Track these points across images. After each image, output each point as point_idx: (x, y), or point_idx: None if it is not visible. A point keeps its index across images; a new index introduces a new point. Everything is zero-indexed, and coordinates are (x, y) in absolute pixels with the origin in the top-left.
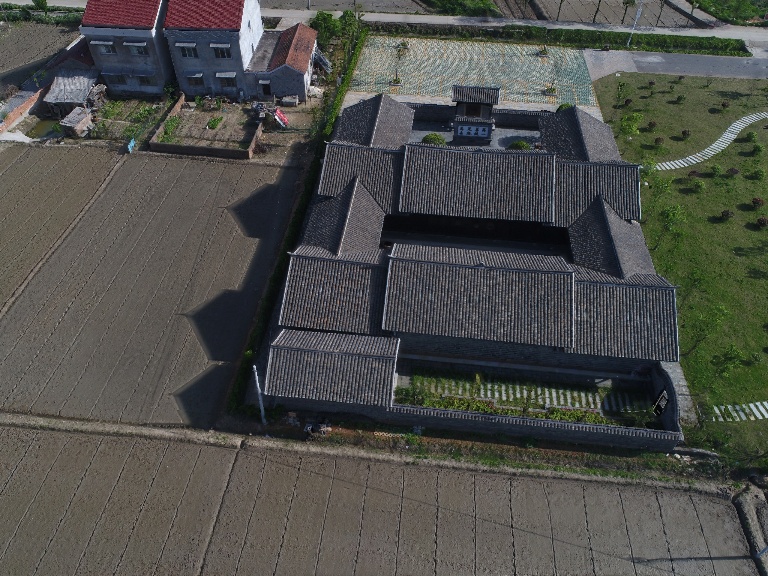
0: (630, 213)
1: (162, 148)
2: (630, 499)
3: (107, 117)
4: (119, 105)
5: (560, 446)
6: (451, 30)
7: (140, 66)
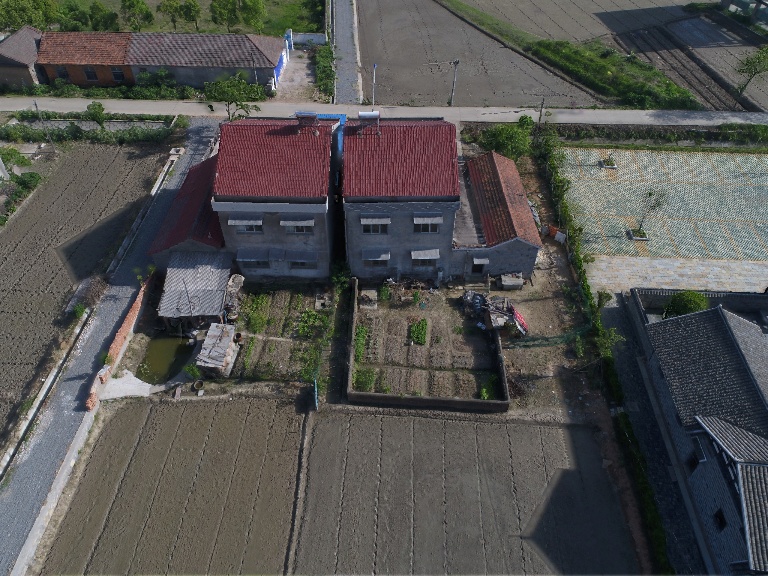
0: None
1: (366, 399)
2: None
3: (255, 331)
4: (264, 304)
5: None
6: (650, 132)
7: (296, 246)
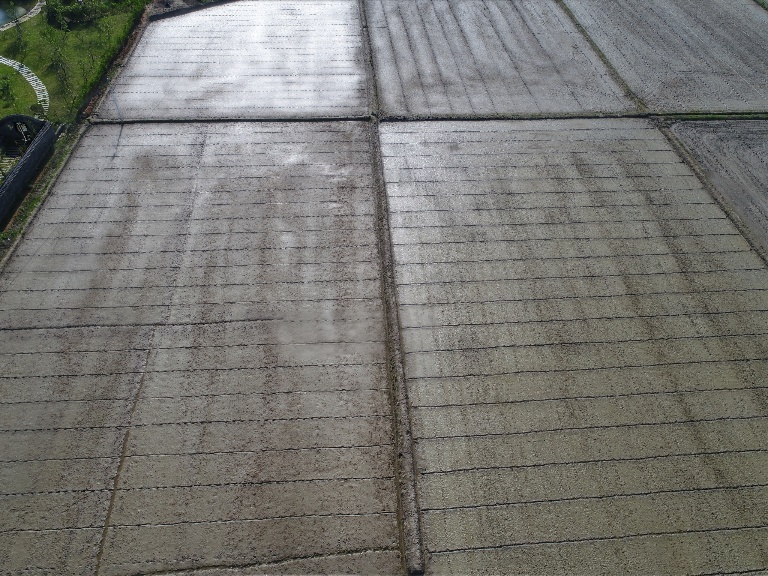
0: None
1: None
2: (81, 154)
3: None
4: None
5: (36, 175)
6: None
7: None
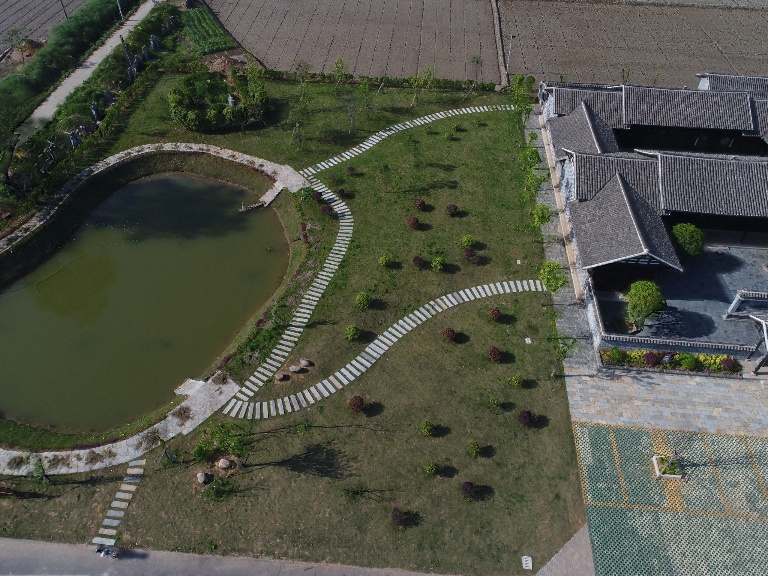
0: (572, 149)
1: None
2: None
3: None
4: None
5: None
6: None
7: None
